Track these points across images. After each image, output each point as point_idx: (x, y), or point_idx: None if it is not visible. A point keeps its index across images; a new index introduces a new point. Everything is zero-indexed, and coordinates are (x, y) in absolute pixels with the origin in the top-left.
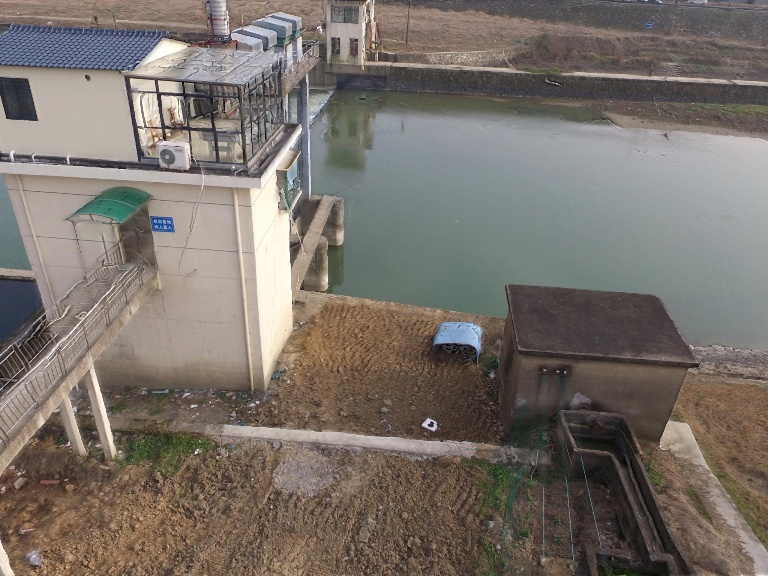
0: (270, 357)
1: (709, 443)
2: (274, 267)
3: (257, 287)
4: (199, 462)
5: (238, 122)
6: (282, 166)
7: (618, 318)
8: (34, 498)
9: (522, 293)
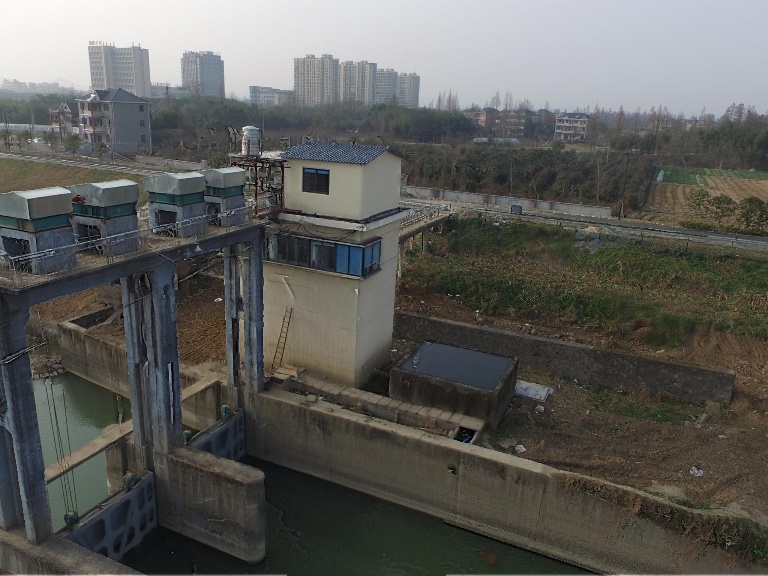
0: None
1: None
2: None
3: None
4: None
5: None
6: None
7: None
8: None
9: None
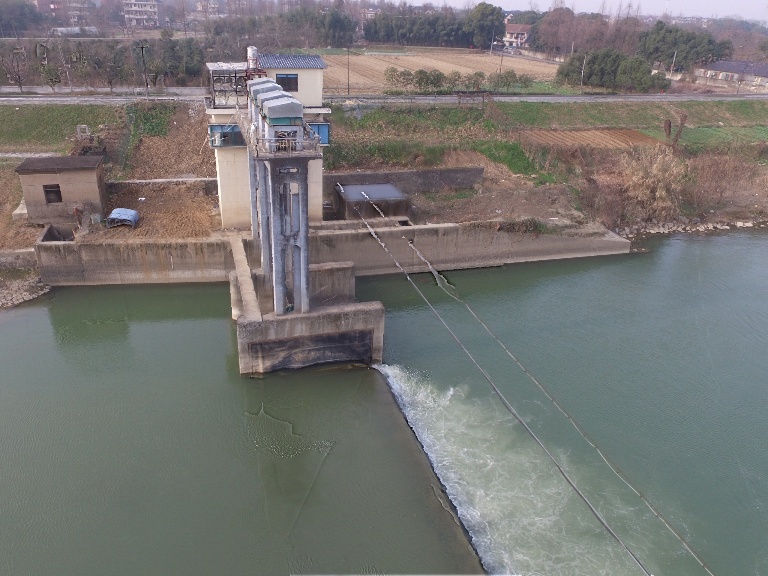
0: None
1: (5, 217)
2: None
3: None
4: None
5: None
6: None
7: (49, 162)
8: None
9: None
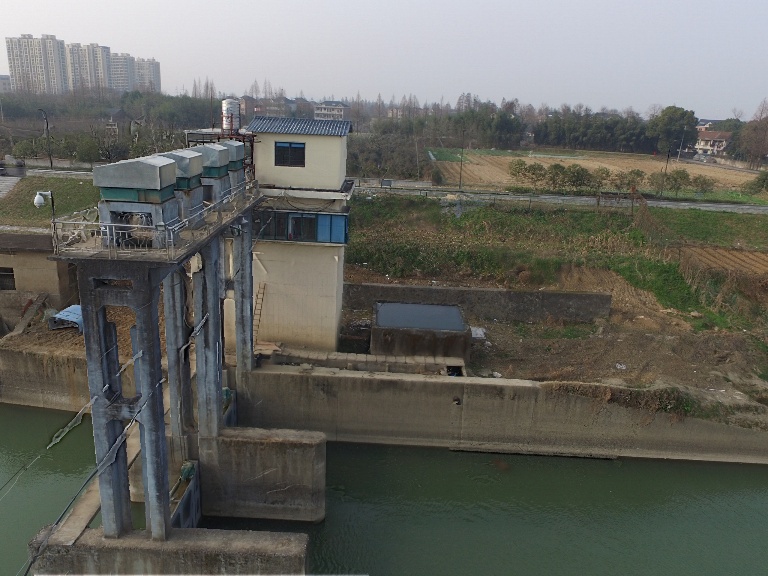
0: None
1: None
2: None
3: None
4: None
5: None
6: None
7: (14, 240)
8: None
9: None
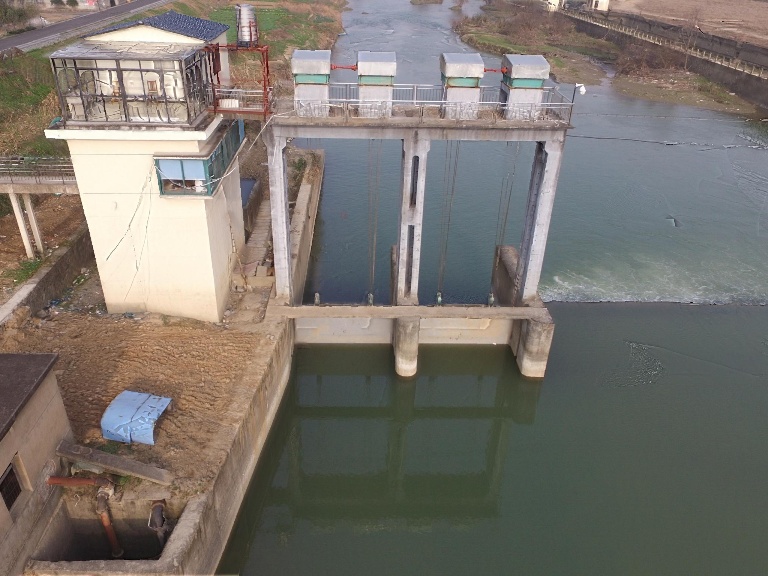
0: (128, 297)
1: None
2: (146, 233)
3: (89, 223)
4: (6, 283)
5: (192, 112)
6: (158, 154)
7: None
8: (21, 249)
9: (29, 362)
